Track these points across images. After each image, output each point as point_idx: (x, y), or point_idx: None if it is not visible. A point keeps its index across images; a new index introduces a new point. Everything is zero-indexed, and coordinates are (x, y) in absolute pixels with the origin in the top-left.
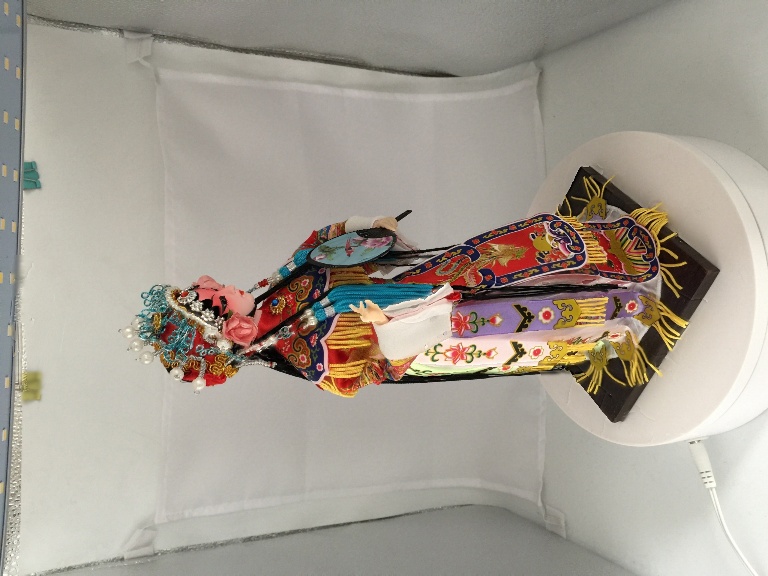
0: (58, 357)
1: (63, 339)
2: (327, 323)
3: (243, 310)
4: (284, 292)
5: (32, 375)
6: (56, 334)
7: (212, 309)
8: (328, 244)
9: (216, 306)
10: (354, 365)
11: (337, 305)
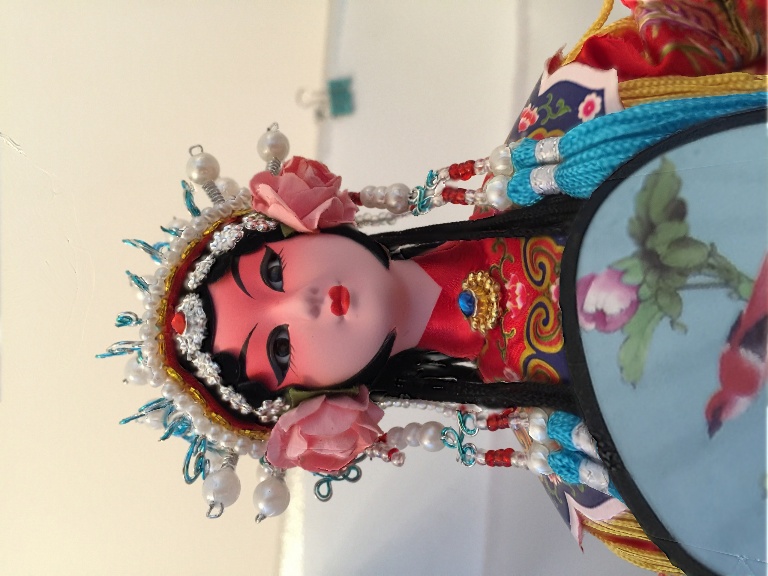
0: (53, 328)
1: (39, 309)
2: (587, 488)
3: (342, 367)
4: (510, 252)
5: (3, 401)
6: (5, 332)
7: (241, 390)
8: (693, 180)
9: (250, 384)
10: (667, 559)
11: (620, 499)
